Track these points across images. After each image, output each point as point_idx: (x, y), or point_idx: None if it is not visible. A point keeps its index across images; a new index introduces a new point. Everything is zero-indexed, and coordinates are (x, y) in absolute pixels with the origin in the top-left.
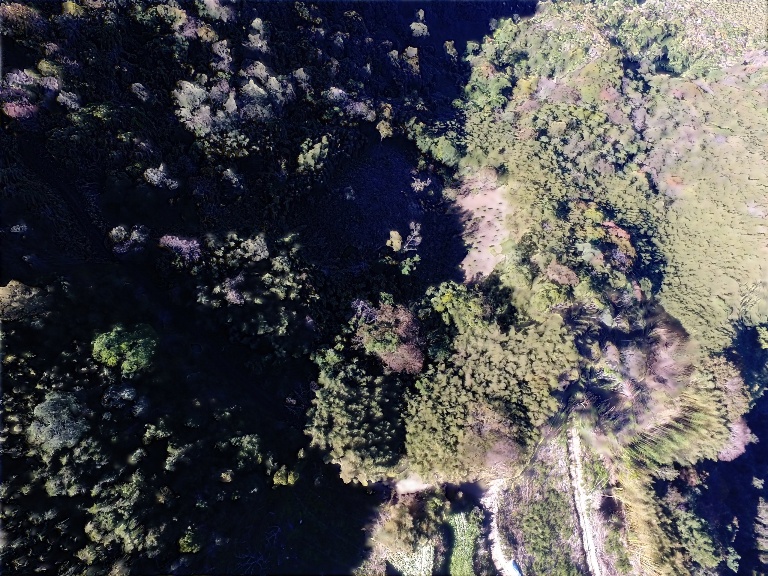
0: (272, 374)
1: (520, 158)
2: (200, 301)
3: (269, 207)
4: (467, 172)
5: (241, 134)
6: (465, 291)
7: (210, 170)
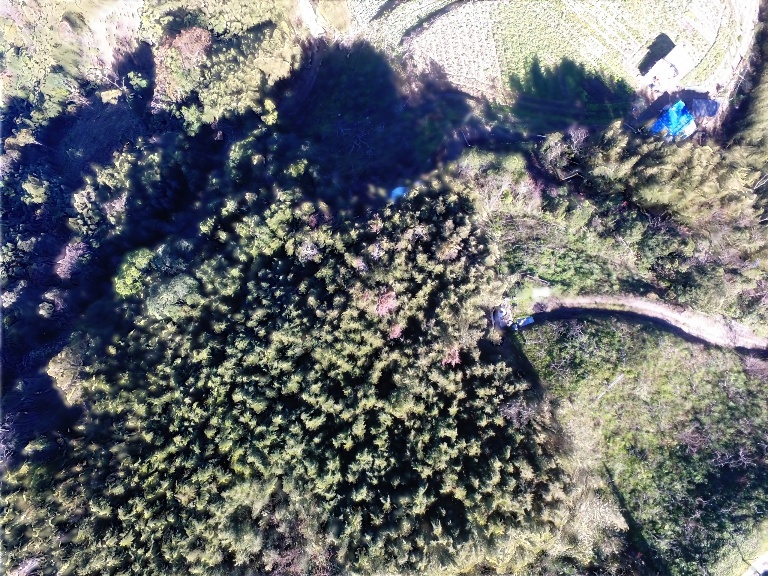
0: (202, 165)
1: (51, 4)
2: (119, 231)
3: (74, 216)
4: (84, 68)
5: (2, 251)
6: (142, 8)
7: (30, 269)
